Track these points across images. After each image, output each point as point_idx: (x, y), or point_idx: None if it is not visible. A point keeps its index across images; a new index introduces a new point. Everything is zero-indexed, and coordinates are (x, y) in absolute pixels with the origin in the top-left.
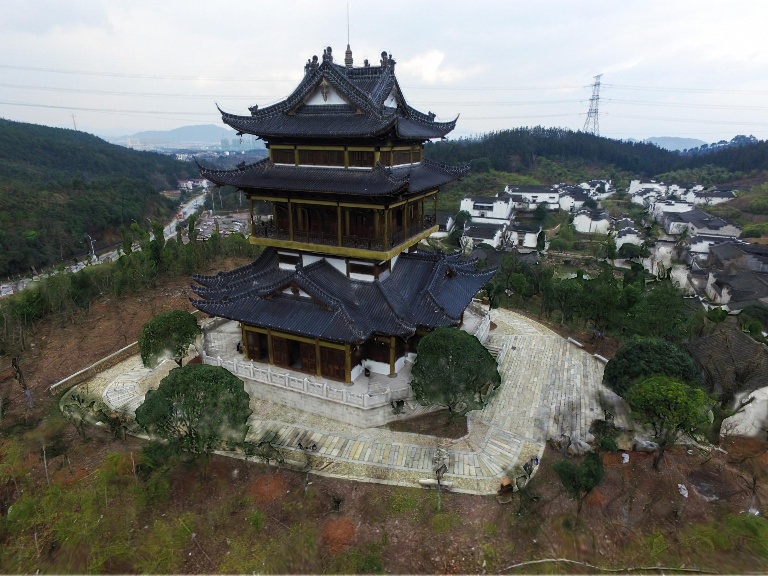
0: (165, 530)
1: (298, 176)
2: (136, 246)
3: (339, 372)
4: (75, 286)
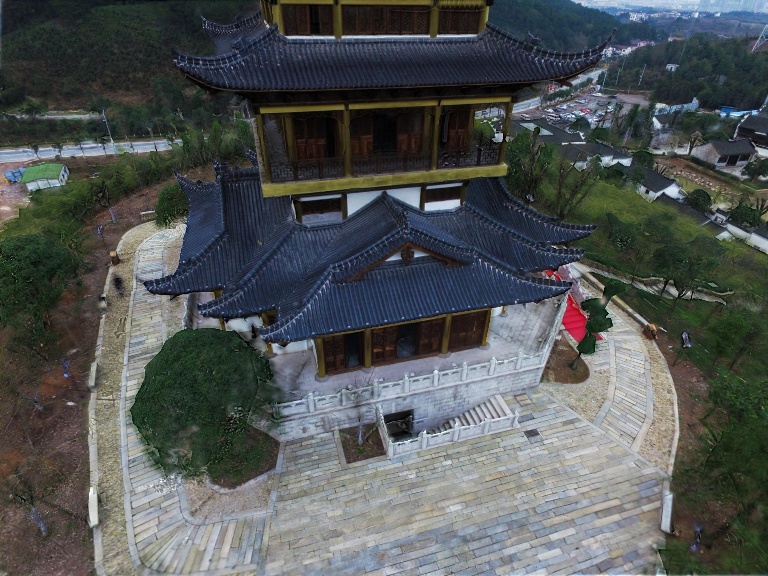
0: (2, 360)
1: None
2: (484, 112)
3: None
4: None
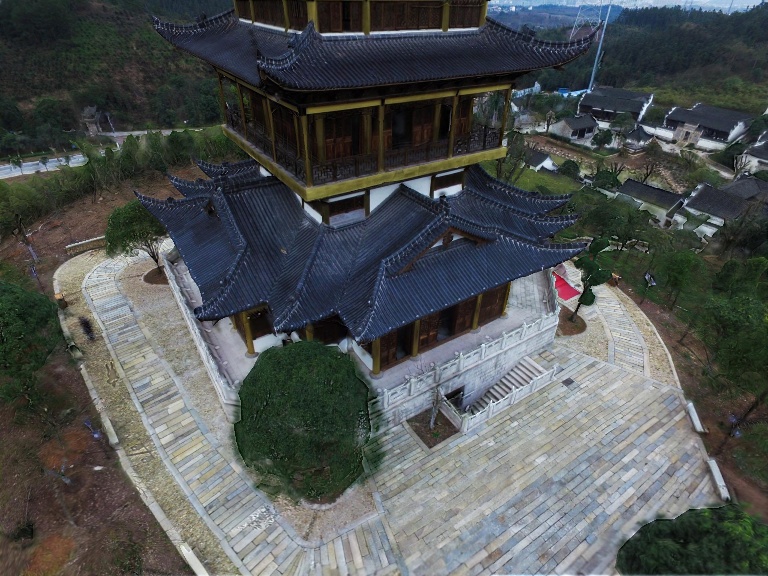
0: None
1: (240, 41)
2: None
3: (245, 335)
4: (177, 146)
